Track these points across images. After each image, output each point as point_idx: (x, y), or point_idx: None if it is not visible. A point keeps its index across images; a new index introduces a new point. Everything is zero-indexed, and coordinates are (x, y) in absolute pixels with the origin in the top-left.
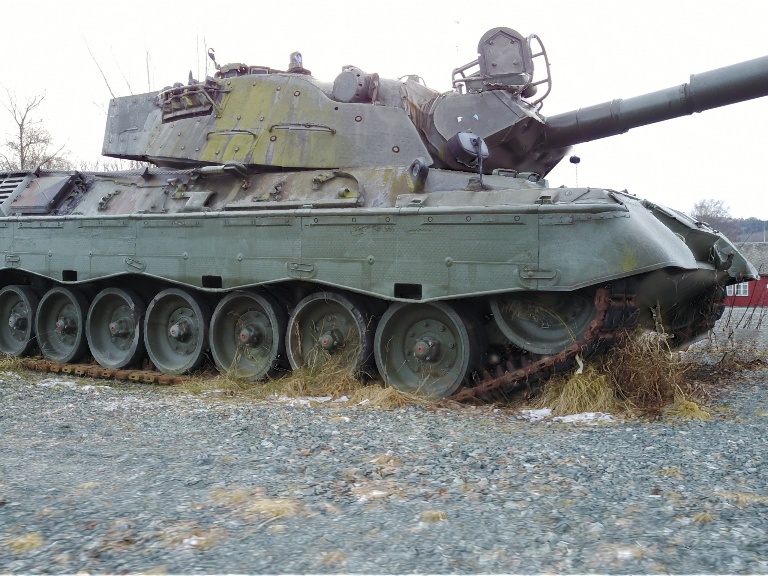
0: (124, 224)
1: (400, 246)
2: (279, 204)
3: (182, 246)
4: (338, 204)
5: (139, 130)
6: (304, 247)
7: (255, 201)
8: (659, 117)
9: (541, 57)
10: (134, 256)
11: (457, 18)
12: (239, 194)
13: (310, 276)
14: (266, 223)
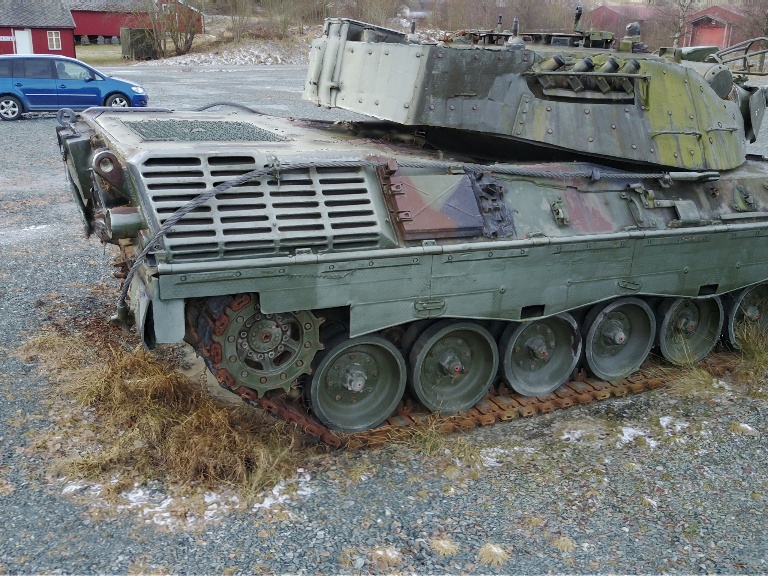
0: (622, 245)
1: None
2: None
3: (685, 261)
4: None
5: (480, 97)
6: None
7: (742, 211)
8: None
9: None
10: (630, 278)
11: None
12: (712, 202)
13: None
14: None
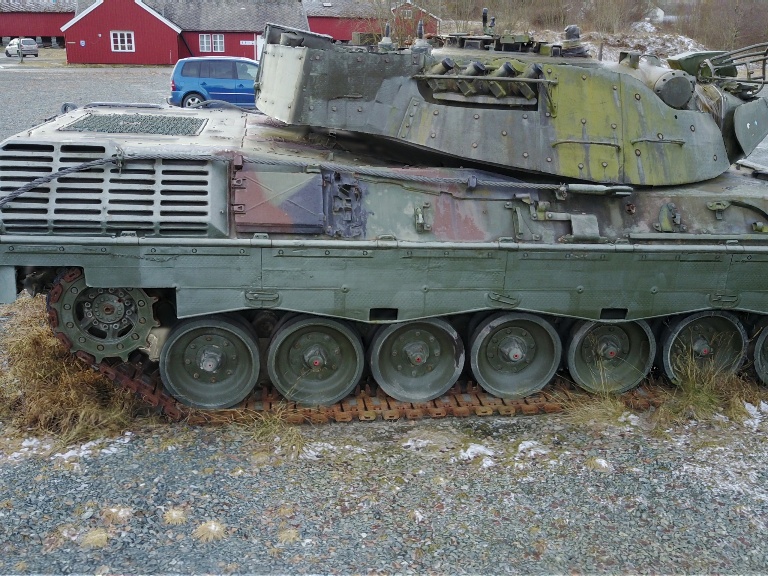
0: (489, 256)
1: None
2: (698, 238)
3: (577, 280)
4: (764, 240)
5: (366, 99)
6: (731, 280)
7: (663, 232)
8: None
9: None
10: (503, 291)
11: None
12: (626, 219)
13: (733, 305)
14: (693, 259)
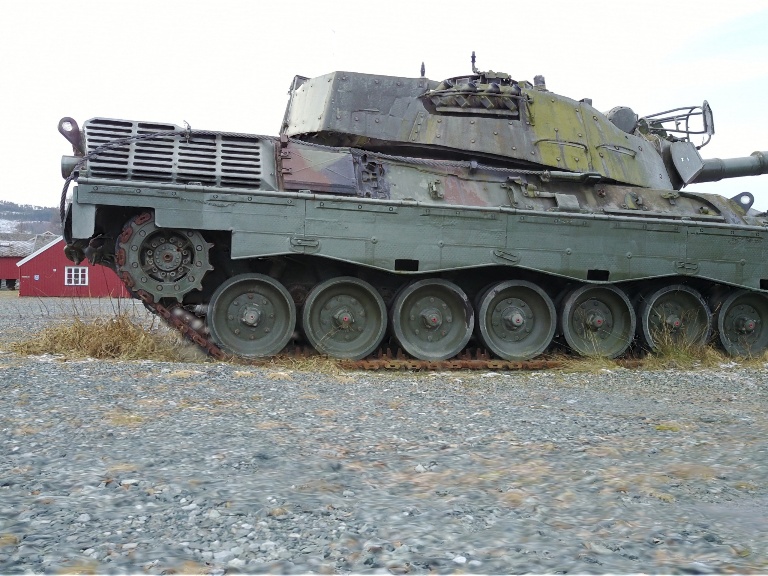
0: (493, 217)
1: (765, 253)
2: (658, 214)
3: (566, 242)
4: (711, 219)
5: (382, 113)
6: (690, 250)
7: (630, 209)
8: (742, 174)
9: (686, 120)
10: (505, 249)
11: (334, 27)
12: (599, 200)
13: (695, 273)
14: (657, 229)
